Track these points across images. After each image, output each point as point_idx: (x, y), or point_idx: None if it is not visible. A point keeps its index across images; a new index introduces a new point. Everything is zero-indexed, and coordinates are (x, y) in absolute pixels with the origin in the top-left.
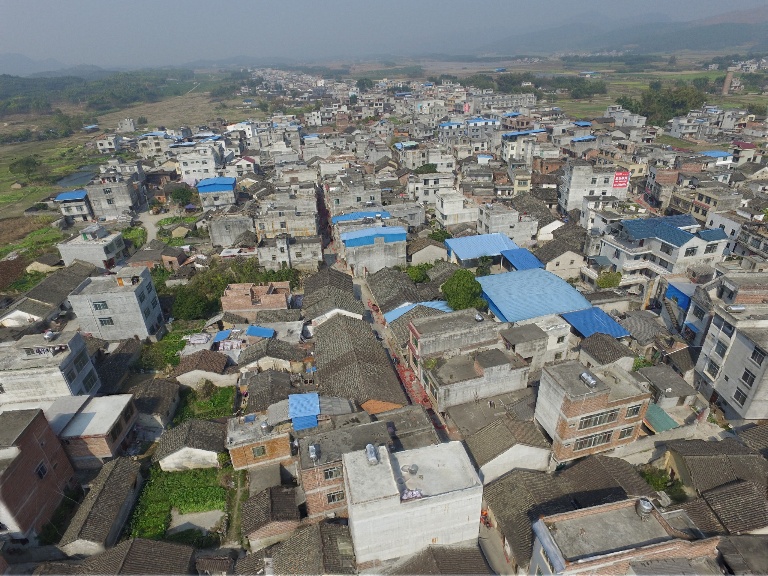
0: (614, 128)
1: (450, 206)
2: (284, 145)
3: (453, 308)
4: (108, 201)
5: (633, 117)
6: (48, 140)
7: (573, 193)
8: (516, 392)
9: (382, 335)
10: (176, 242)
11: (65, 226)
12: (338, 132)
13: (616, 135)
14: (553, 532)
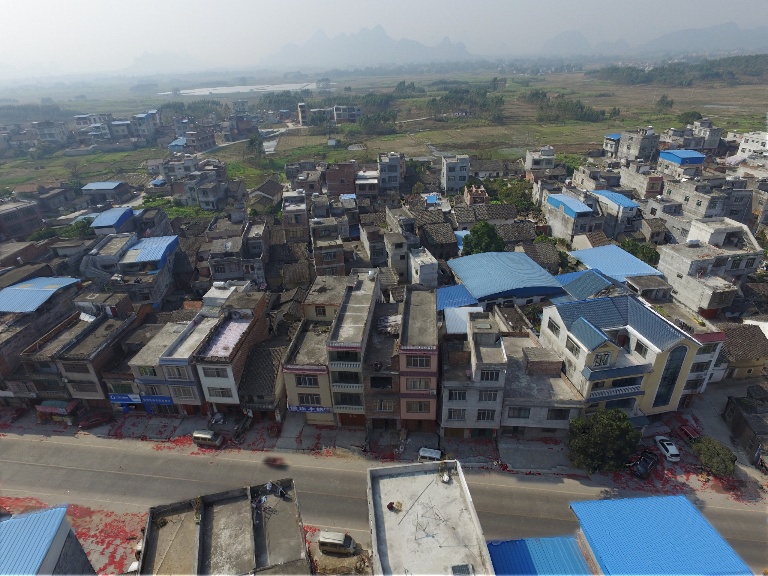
0: None
1: (696, 232)
2: None
3: None
4: (628, 147)
5: None
6: None
7: None
8: (367, 256)
9: None
10: None
11: (596, 155)
12: None
13: None
14: (262, 224)
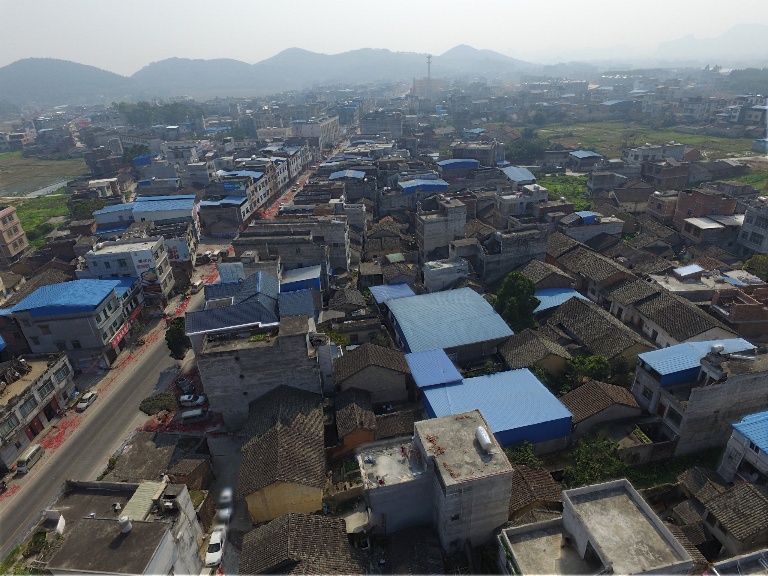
0: None
1: None
2: None
3: None
4: None
5: None
6: None
7: None
8: None
9: None
10: None
11: None
12: None
13: None
14: None
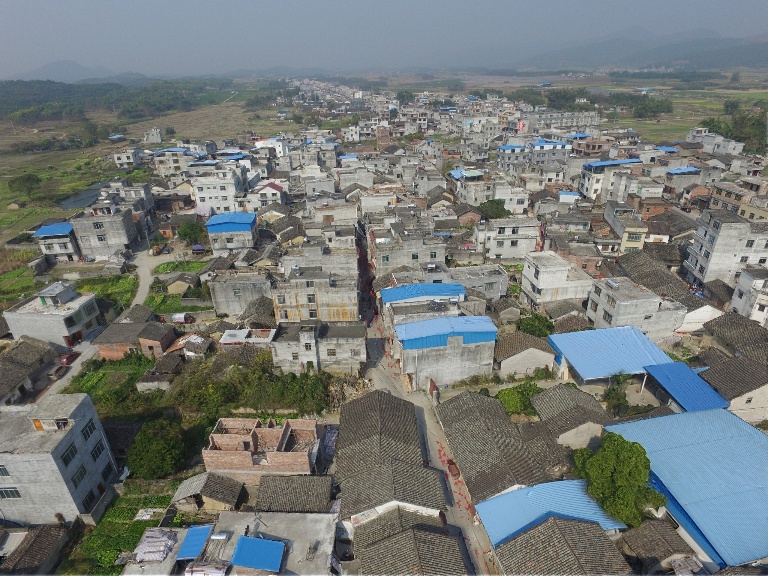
0: (706, 156)
1: (548, 277)
2: (318, 169)
3: (602, 505)
4: (99, 238)
5: (728, 143)
6: (71, 150)
7: (716, 259)
8: None
9: (471, 542)
10: (171, 302)
11: (44, 268)
12: (379, 152)
13: (712, 165)
14: None
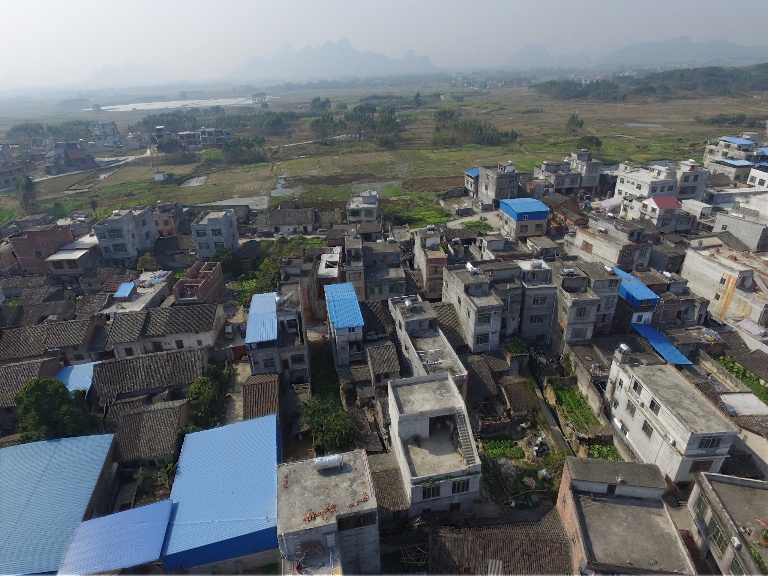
0: None
1: None
2: None
3: None
4: (486, 187)
5: None
6: (755, 128)
7: None
8: None
9: None
10: None
11: (456, 195)
12: None
13: None
14: None
